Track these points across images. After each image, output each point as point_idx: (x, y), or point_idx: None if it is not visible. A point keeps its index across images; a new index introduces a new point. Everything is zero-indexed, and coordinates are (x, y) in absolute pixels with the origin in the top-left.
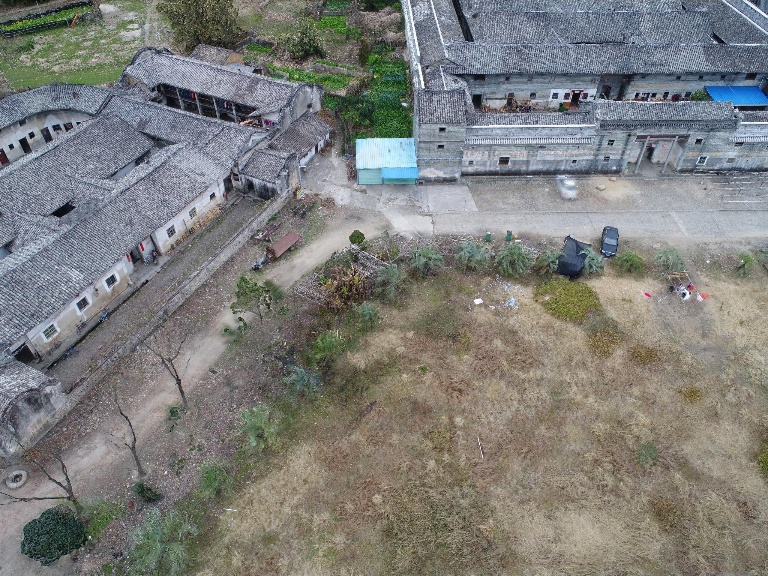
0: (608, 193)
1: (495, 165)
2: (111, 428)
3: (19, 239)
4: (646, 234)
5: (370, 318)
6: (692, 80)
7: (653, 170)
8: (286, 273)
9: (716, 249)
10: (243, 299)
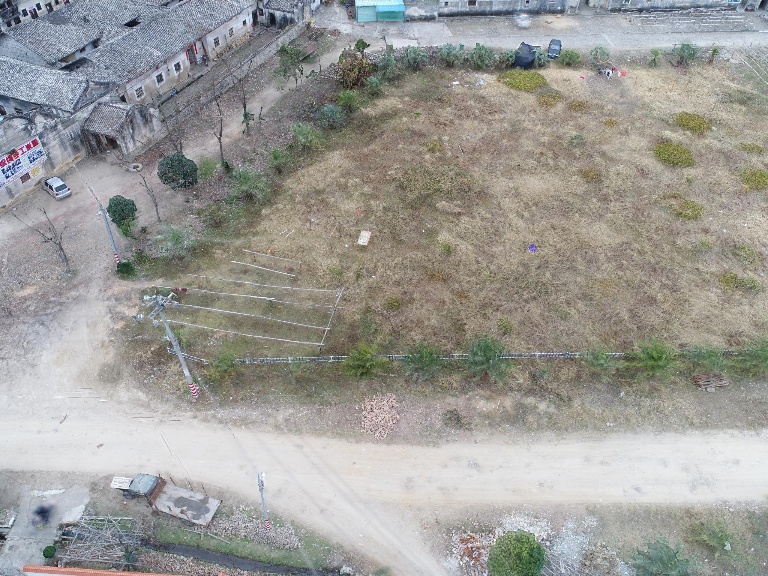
0: (554, 25)
1: (465, 6)
2: (195, 145)
3: (104, 37)
4: (583, 46)
5: (376, 85)
6: None
7: (590, 11)
8: (308, 70)
9: (635, 53)
10: (285, 57)
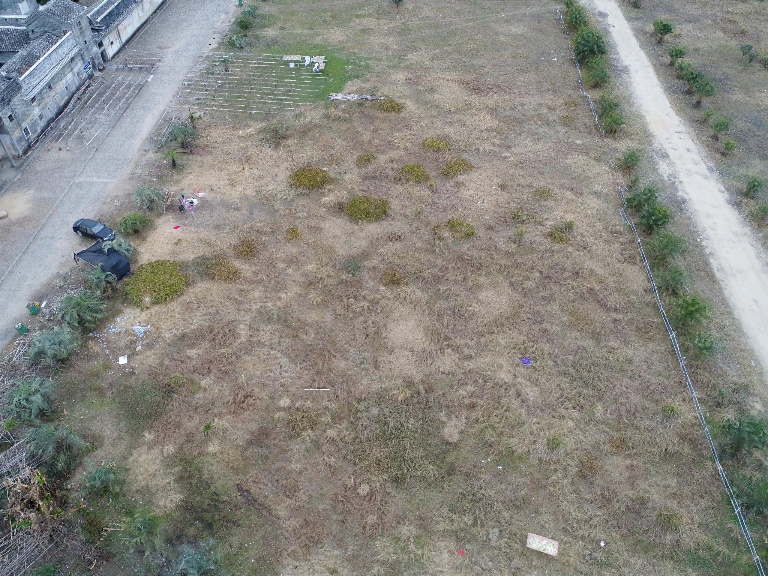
0: (15, 213)
1: None
2: None
3: None
4: (97, 205)
5: (113, 473)
6: None
7: (5, 171)
8: None
9: (143, 170)
10: None
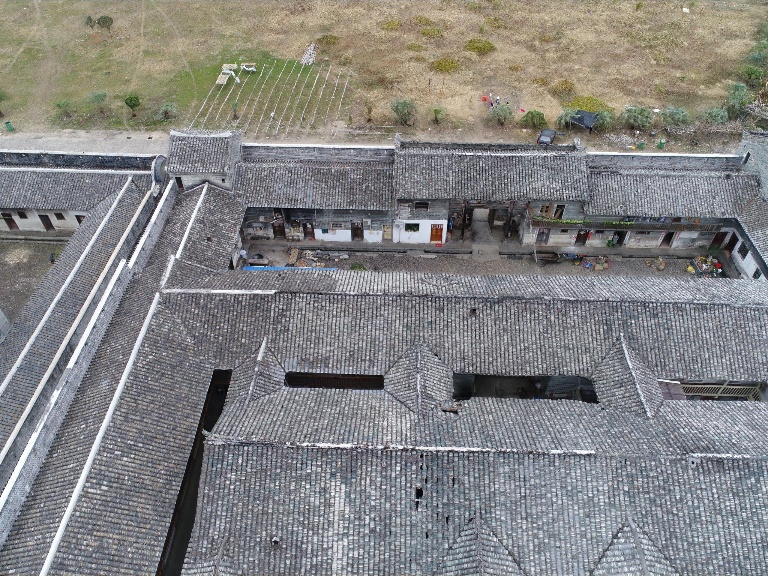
0: None
1: None
2: None
3: None
4: None
5: None
6: None
7: None
8: None
9: (447, 137)
10: None
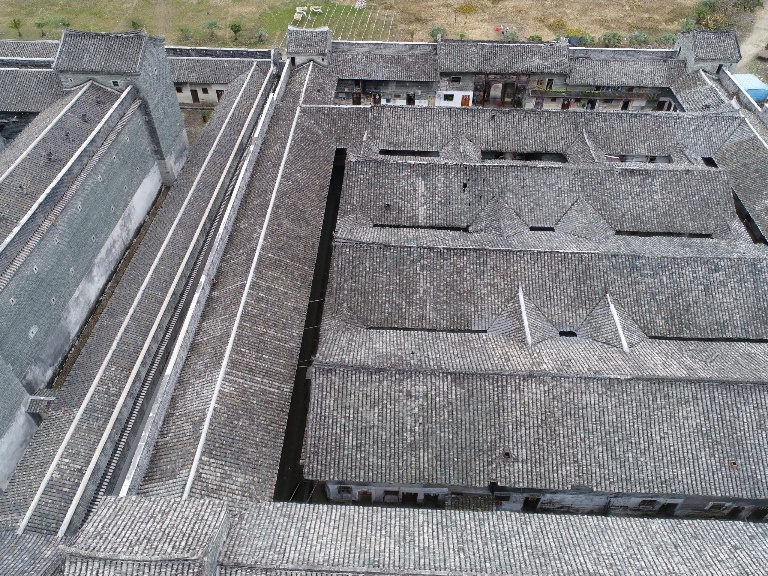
0: None
1: None
2: None
3: None
4: None
5: None
6: None
7: None
8: (751, 48)
9: None
10: None
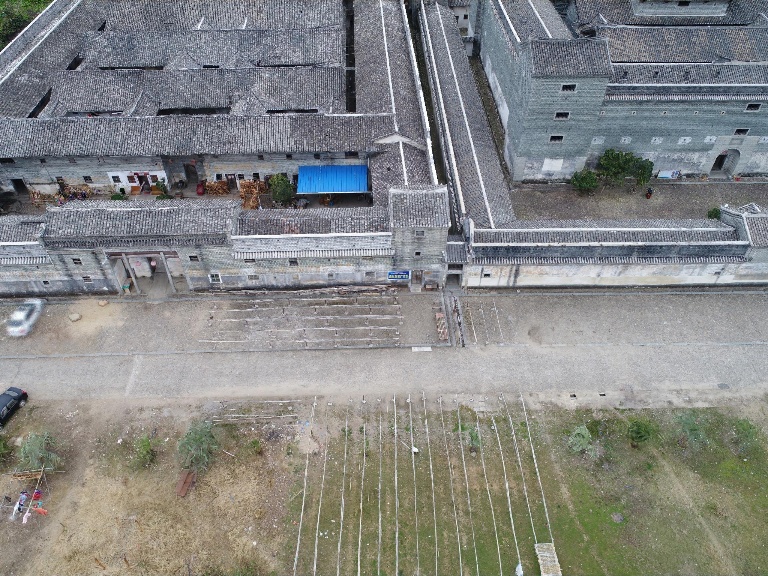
0: (79, 326)
1: None
2: None
3: None
4: (72, 394)
5: None
6: (280, 159)
7: (166, 288)
8: None
9: (146, 419)
10: None
